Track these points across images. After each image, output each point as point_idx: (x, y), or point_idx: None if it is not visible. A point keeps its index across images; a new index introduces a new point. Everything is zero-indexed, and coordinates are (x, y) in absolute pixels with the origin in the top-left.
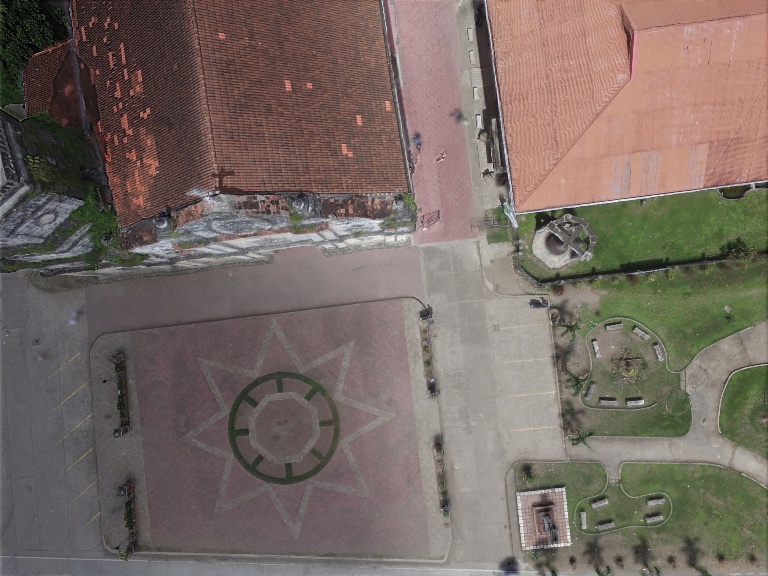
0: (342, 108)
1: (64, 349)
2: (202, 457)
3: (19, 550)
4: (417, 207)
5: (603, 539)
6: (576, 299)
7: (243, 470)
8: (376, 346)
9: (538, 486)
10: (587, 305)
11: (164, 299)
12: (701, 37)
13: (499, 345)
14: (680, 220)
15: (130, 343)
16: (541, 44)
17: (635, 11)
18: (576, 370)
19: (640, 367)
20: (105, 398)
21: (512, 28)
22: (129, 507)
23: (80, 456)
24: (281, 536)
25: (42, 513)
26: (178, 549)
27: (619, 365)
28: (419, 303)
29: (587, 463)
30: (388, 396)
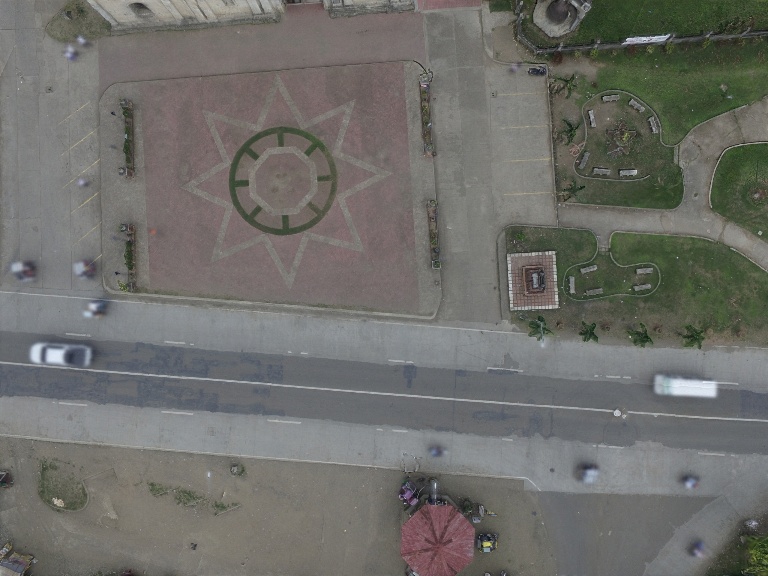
0: None
1: (75, 97)
2: (202, 205)
3: (22, 287)
4: None
5: (591, 305)
6: (574, 70)
7: (241, 219)
8: (376, 106)
9: (529, 250)
10: (585, 77)
11: (173, 53)
12: None
13: (496, 111)
14: None
15: (139, 93)
16: None
17: None
18: None
19: (634, 140)
20: (112, 145)
21: None
22: (130, 247)
23: (85, 200)
24: (275, 285)
25: (46, 253)
26: (175, 292)
27: (614, 134)
28: (420, 66)
29: (578, 230)
30: (386, 155)
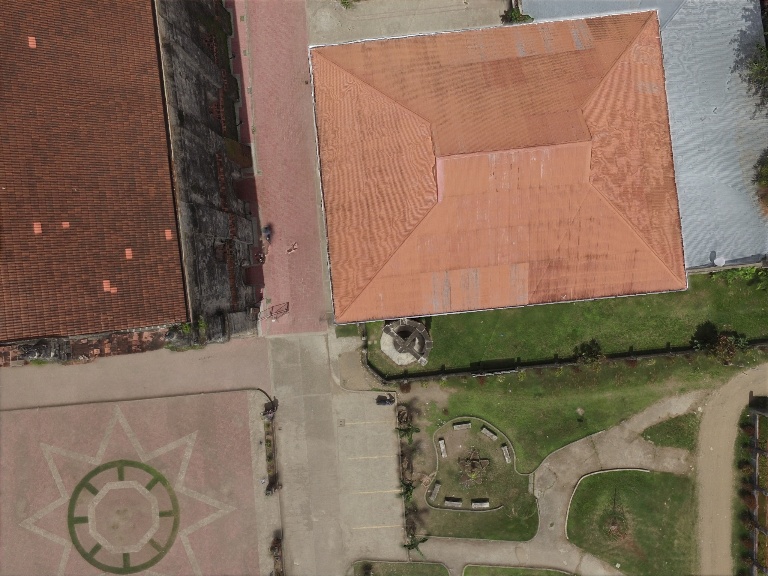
0: (107, 243)
1: None
2: (41, 543)
3: None
4: (266, 298)
5: None
6: (424, 396)
7: (81, 558)
8: (219, 437)
9: None
10: (436, 403)
11: (10, 382)
12: (507, 164)
13: (344, 441)
14: (533, 320)
15: None
16: (361, 157)
17: (442, 134)
18: (422, 469)
19: (488, 468)
20: None
21: (336, 137)
22: None
23: None
24: None
25: None
26: None
27: (465, 466)
28: (264, 395)
29: (430, 564)
30: (229, 489)
